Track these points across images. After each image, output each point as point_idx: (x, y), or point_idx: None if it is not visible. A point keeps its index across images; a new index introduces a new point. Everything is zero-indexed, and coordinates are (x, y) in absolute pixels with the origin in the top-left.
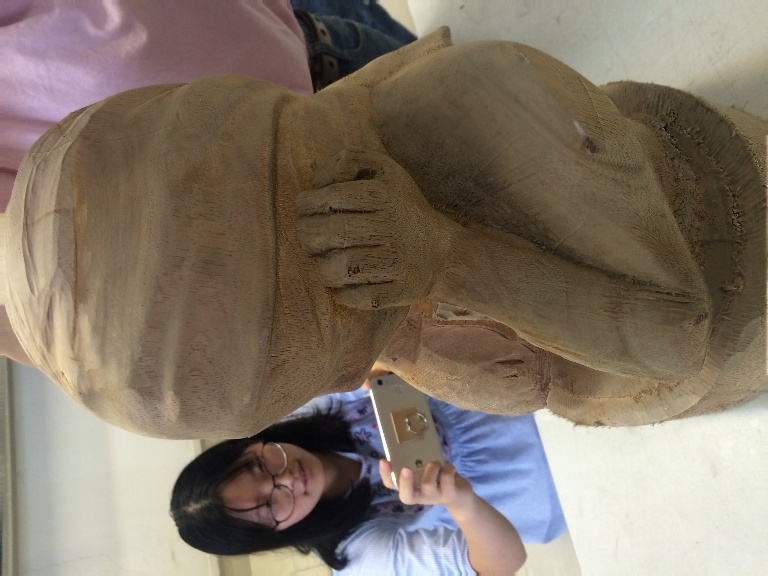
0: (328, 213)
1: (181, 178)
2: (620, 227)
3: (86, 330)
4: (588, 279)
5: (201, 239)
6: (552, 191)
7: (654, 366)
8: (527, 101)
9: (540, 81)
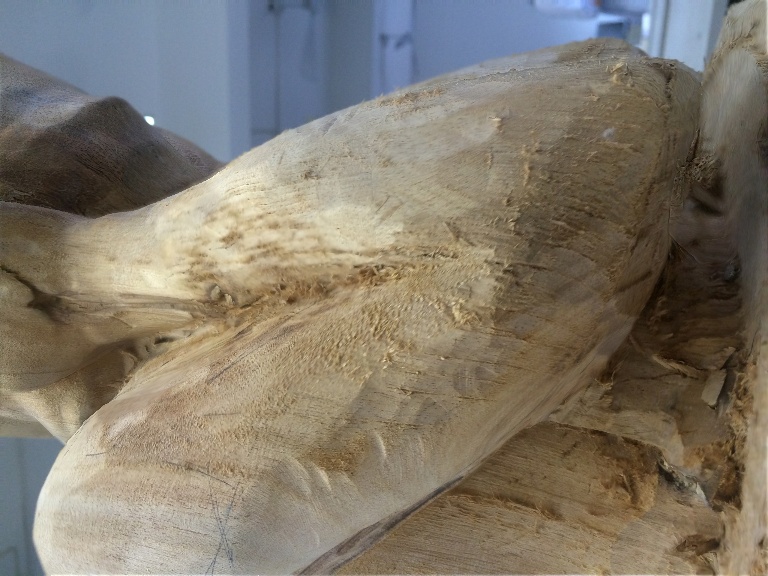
0: None
1: None
2: None
3: None
4: None
5: None
6: None
7: None
8: None
9: None
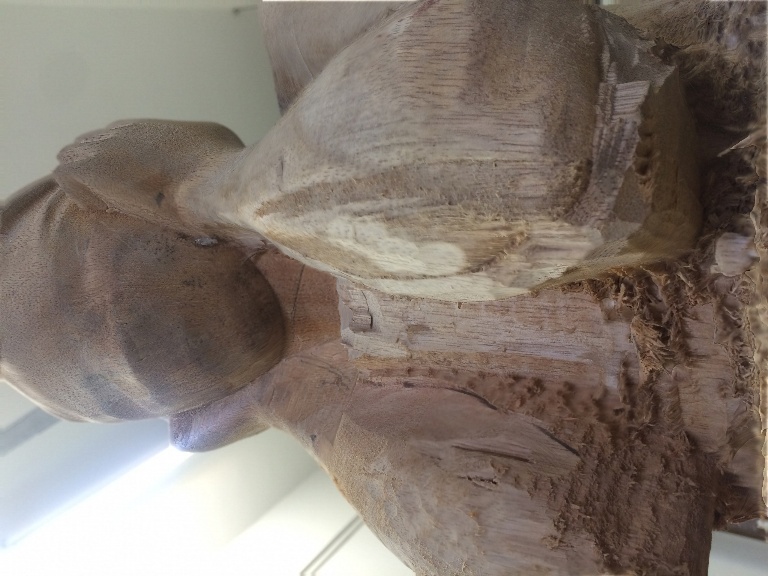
0: None
1: None
2: None
3: None
4: None
5: None
6: None
7: (369, 152)
8: None
9: None
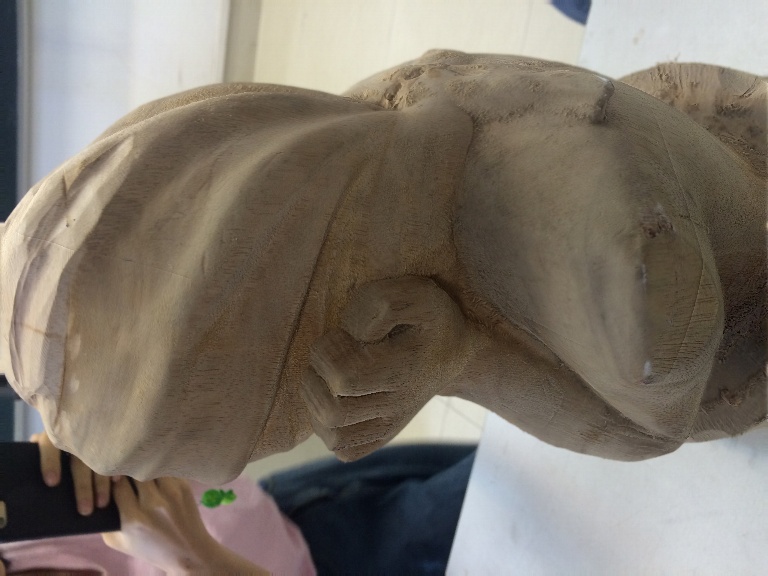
0: (334, 398)
1: (186, 354)
2: (637, 407)
3: (67, 429)
4: (584, 407)
5: (193, 412)
6: (588, 378)
7: None
8: (613, 324)
9: (641, 311)
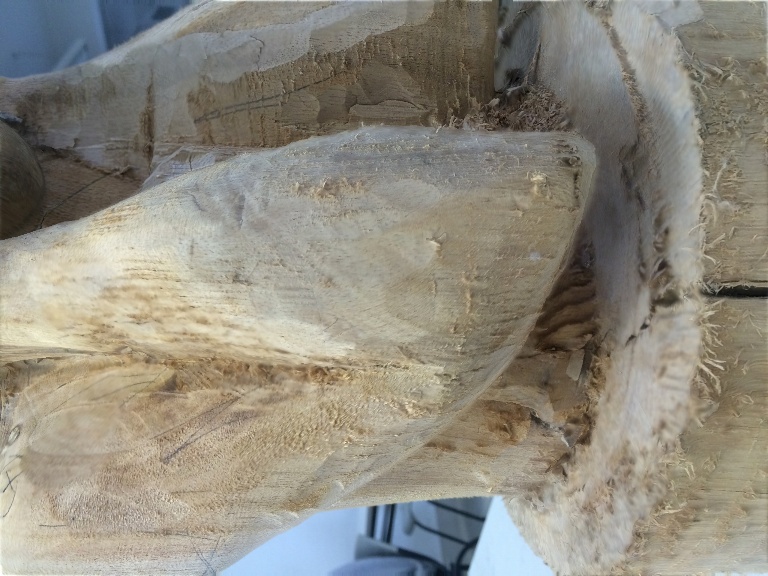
0: None
1: None
2: None
3: None
4: None
5: None
6: None
7: None
8: None
9: None
